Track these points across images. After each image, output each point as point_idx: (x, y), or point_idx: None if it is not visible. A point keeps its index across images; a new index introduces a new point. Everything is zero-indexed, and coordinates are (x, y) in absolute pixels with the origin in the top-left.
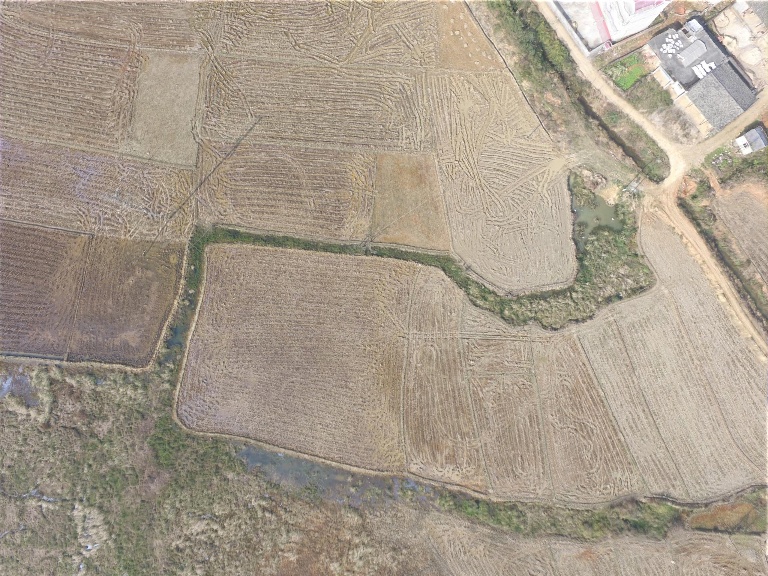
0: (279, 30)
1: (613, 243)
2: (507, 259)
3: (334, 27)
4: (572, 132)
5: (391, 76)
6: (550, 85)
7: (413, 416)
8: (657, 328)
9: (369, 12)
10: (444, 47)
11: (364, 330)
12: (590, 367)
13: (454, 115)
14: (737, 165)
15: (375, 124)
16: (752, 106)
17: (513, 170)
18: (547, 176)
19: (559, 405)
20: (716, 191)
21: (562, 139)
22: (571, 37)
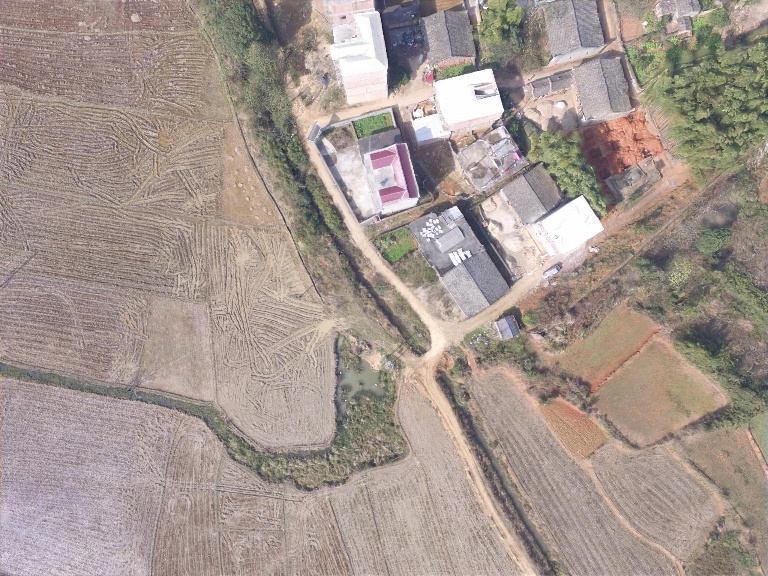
0: (63, 165)
1: (373, 409)
2: (269, 416)
3: (119, 167)
4: (341, 297)
5: (171, 222)
6: (324, 248)
7: (162, 564)
8: (406, 498)
9: (155, 155)
10: (226, 198)
11: (122, 474)
12: (338, 530)
13: (230, 267)
14: (494, 347)
15: (151, 269)
16: (511, 292)
17: (283, 328)
18: (315, 337)
19: (305, 565)
20: (472, 370)
21: (332, 302)
22: (346, 204)
